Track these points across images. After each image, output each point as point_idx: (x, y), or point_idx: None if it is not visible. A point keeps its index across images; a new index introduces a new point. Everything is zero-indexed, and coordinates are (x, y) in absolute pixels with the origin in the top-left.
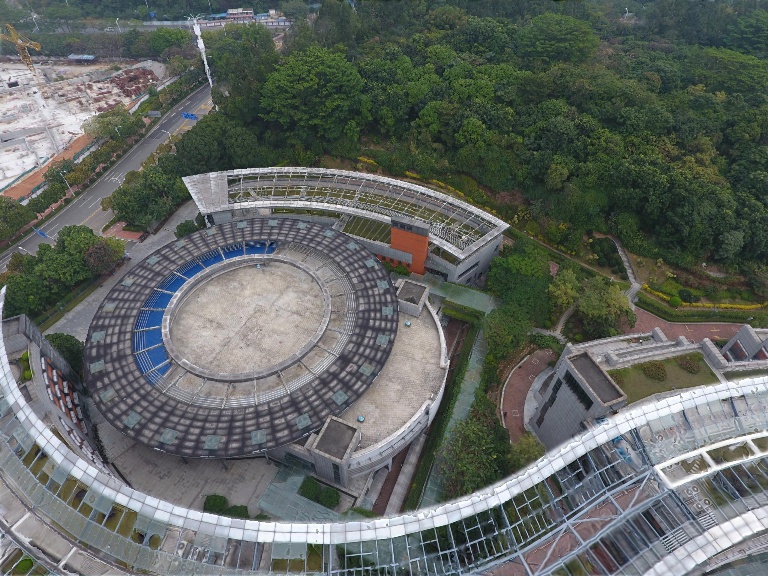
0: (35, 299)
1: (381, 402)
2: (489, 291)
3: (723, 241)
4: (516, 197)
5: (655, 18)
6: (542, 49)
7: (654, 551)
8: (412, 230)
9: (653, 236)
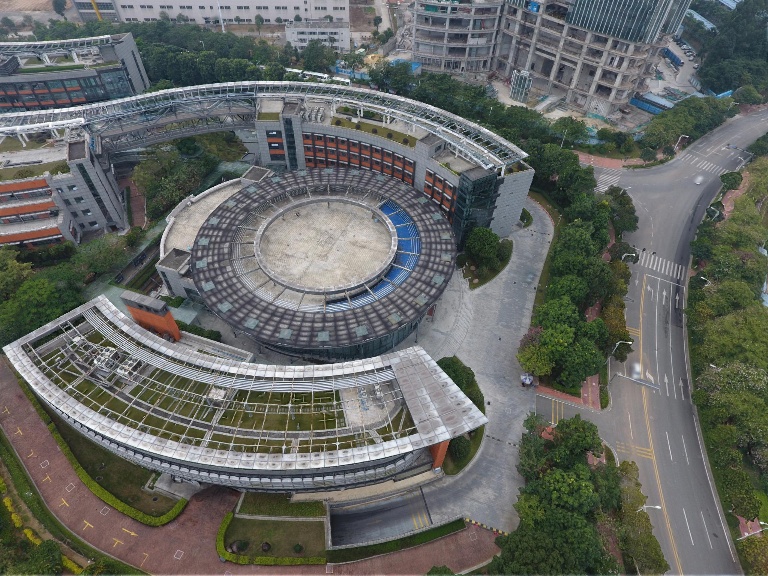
0: None
1: None
2: None
3: None
4: None
5: None
6: None
7: (113, 106)
8: None
9: None
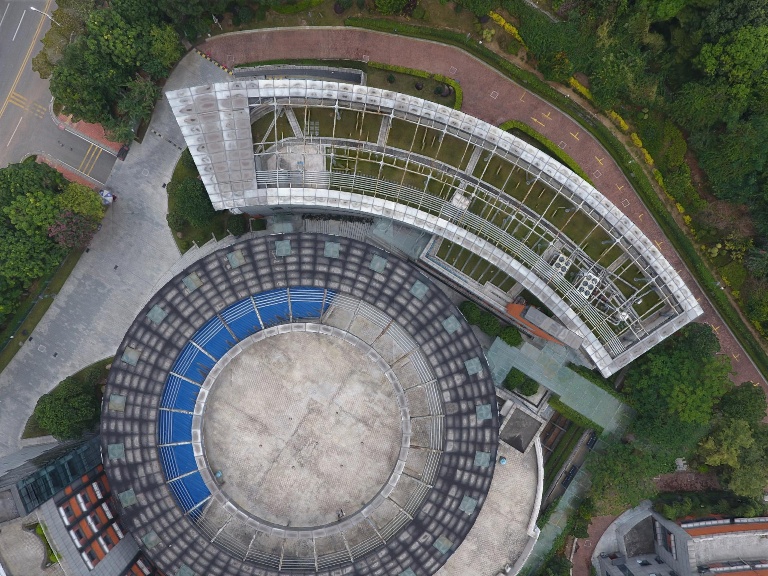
0: (7, 306)
1: (451, 563)
2: (621, 393)
3: None
4: (740, 221)
5: None
6: None
7: None
8: (551, 335)
9: None
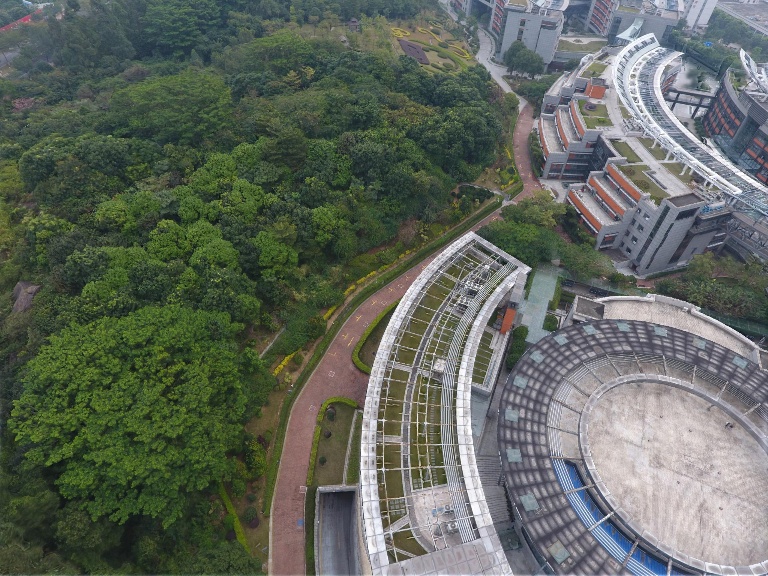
0: None
1: None
2: None
3: (501, 129)
4: None
5: (77, 54)
6: (215, 118)
7: None
8: None
9: (474, 161)
